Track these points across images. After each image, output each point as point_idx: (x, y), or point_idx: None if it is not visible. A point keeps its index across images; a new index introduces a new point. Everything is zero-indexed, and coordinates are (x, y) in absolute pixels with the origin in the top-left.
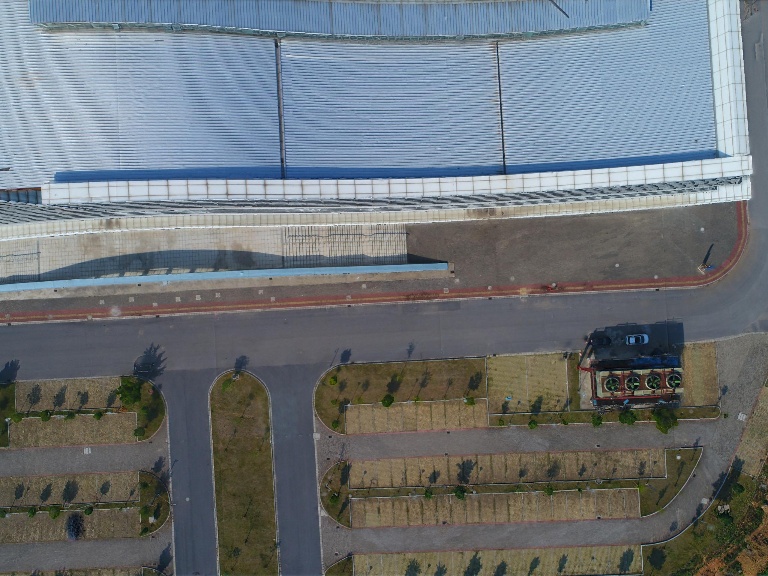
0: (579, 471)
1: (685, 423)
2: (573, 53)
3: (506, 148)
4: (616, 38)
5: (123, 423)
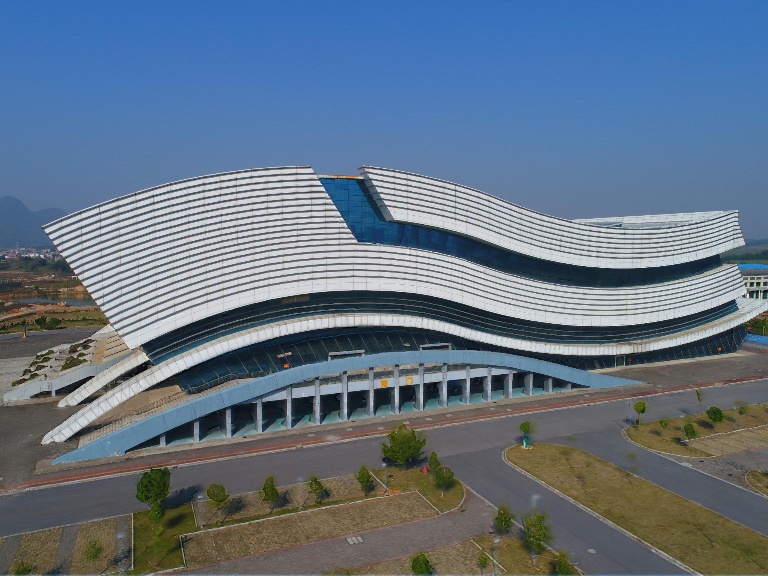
0: None
1: None
2: None
3: None
4: None
5: (401, 503)
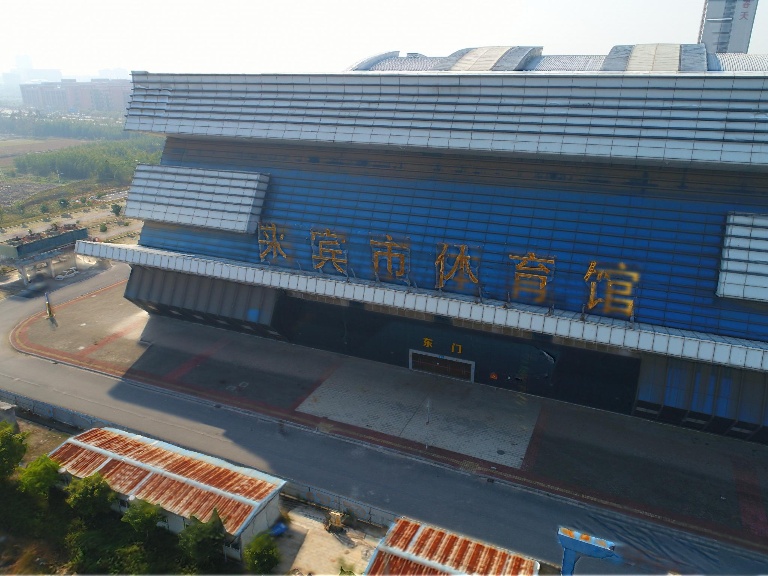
0: None
1: None
2: None
3: None
4: None
5: None
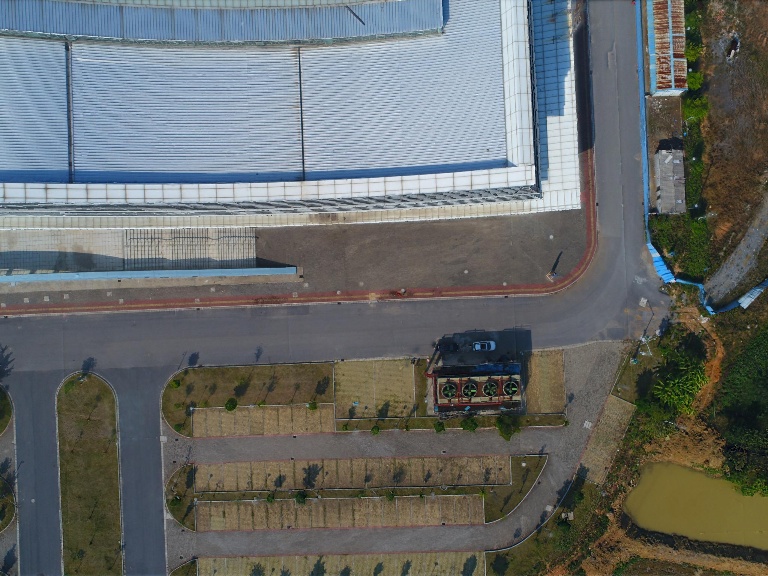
0: (424, 477)
1: (531, 430)
2: (373, 60)
3: (306, 154)
4: (415, 46)
5: None
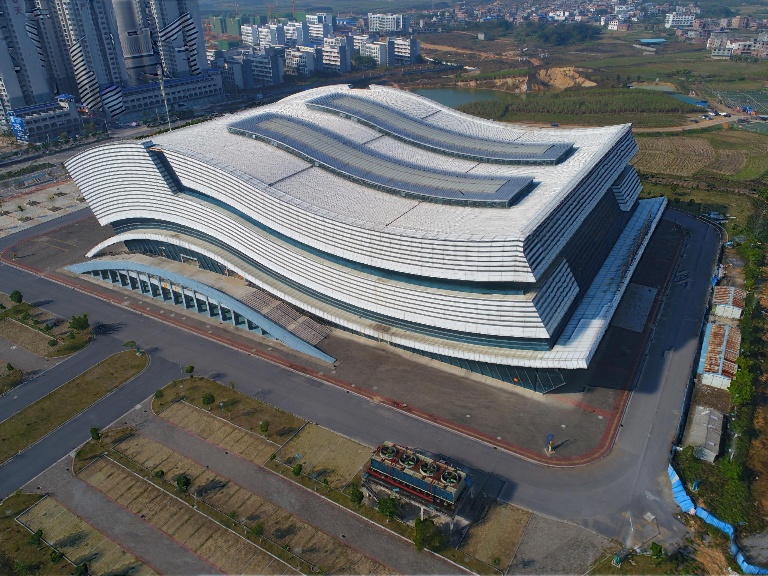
0: (305, 547)
1: (453, 568)
2: None
3: None
4: None
5: None
